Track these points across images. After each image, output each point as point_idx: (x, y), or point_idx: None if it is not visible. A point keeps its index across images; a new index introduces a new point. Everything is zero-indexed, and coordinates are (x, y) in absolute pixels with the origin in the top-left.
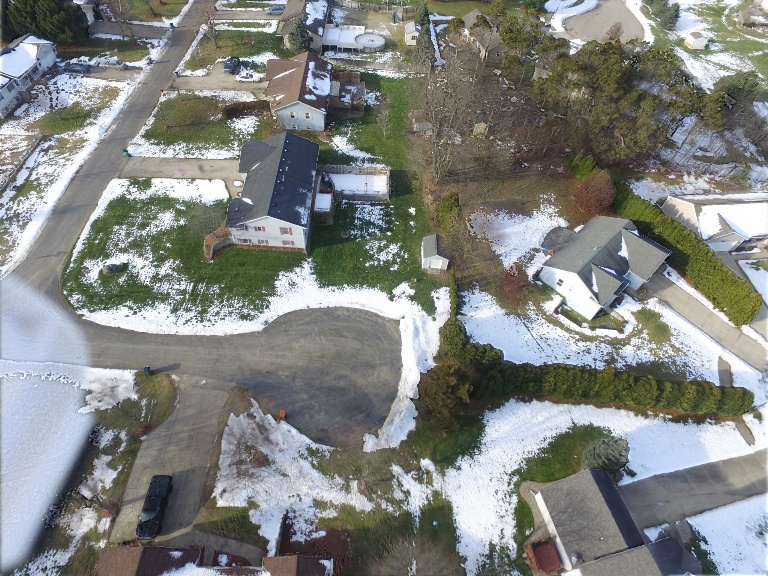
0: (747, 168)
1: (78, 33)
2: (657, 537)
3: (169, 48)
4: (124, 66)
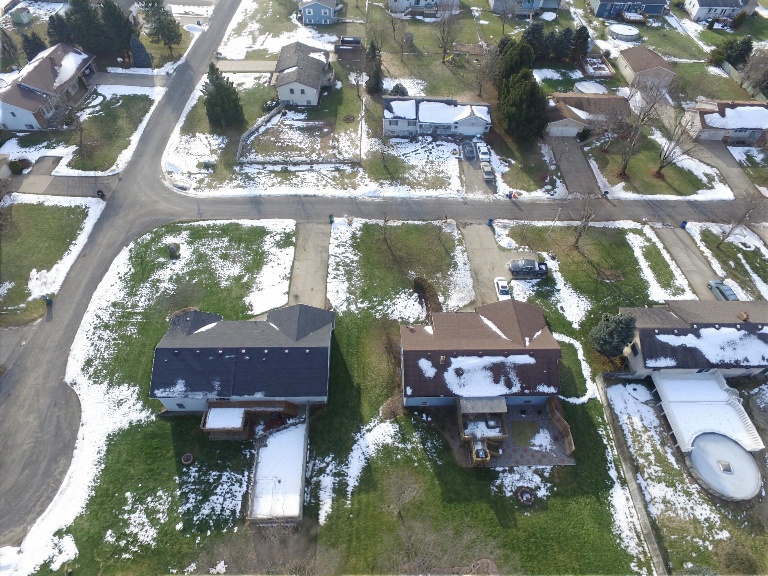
0: None
1: (515, 131)
2: None
3: (552, 204)
4: (488, 179)
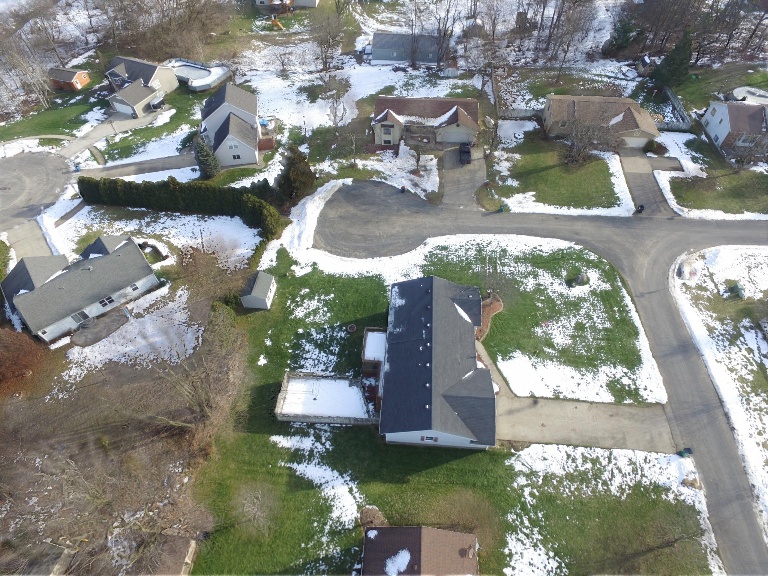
0: None
1: None
2: None
3: None
4: None
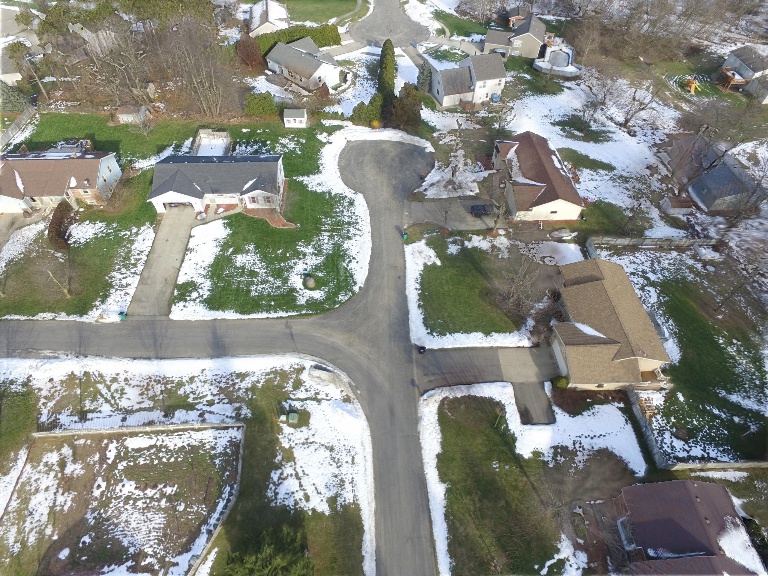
0: (226, 8)
1: None
2: None
3: None
4: None
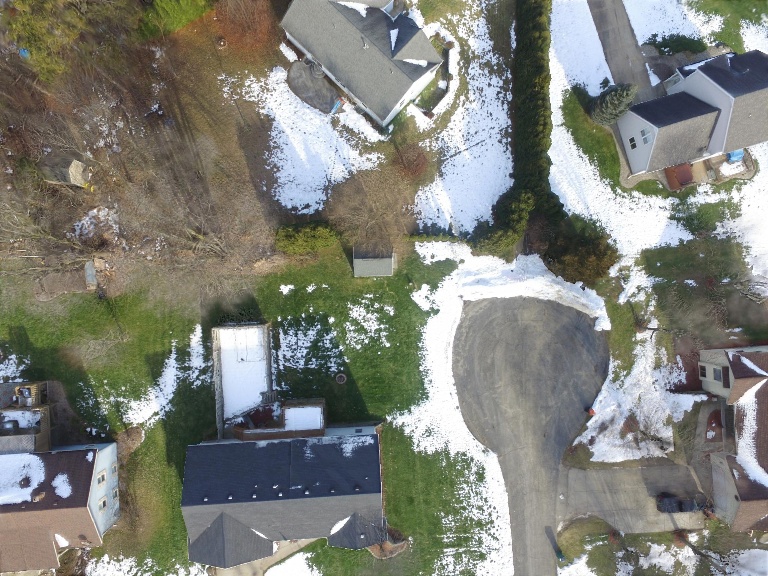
0: None
1: None
2: (657, 76)
3: None
4: None
